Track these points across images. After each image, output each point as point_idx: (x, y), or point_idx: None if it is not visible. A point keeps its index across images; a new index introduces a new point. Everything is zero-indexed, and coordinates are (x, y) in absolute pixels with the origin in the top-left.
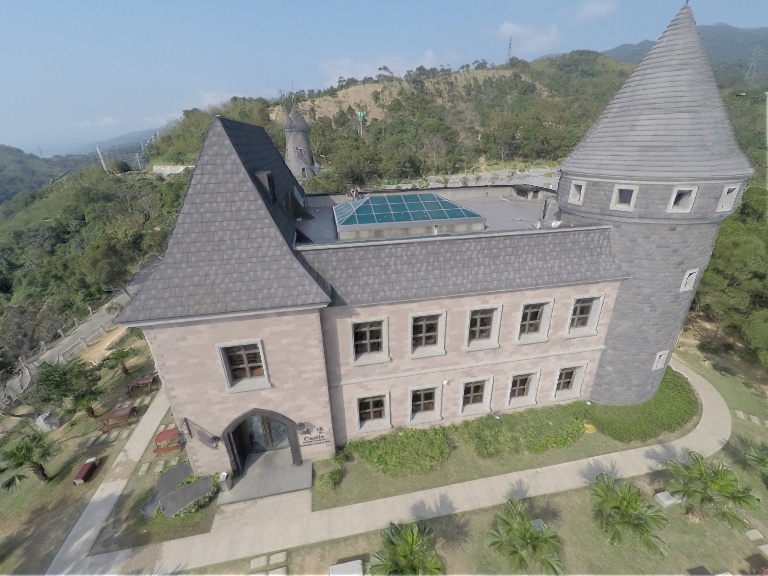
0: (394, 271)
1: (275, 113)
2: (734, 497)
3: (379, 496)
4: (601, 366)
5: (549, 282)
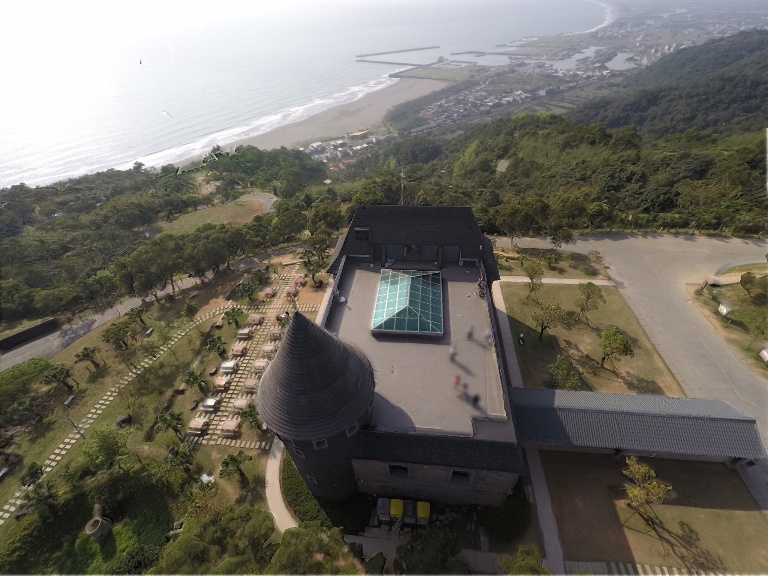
0: None
1: None
2: (245, 413)
3: None
4: None
5: None
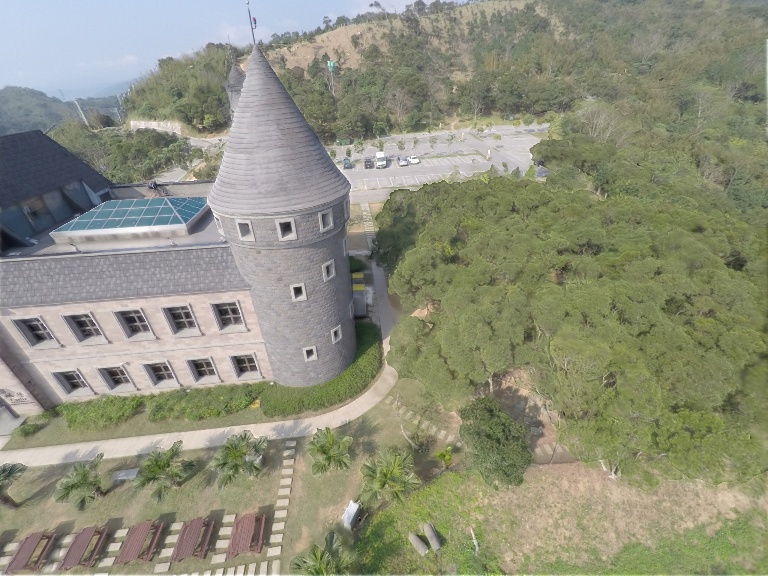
0: (36, 281)
1: (246, 63)
2: None
3: (54, 444)
4: (269, 355)
5: (173, 291)
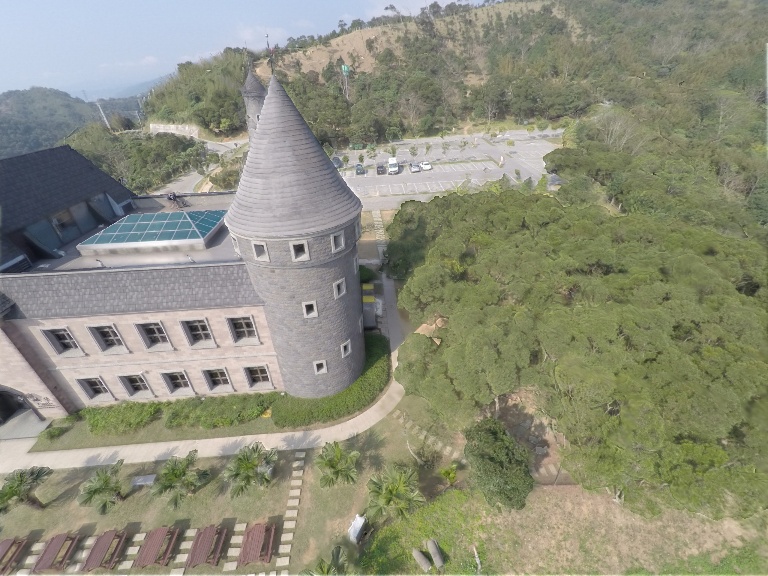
0: (64, 294)
1: (262, 67)
2: (248, 476)
3: (77, 447)
4: (280, 367)
5: (191, 306)
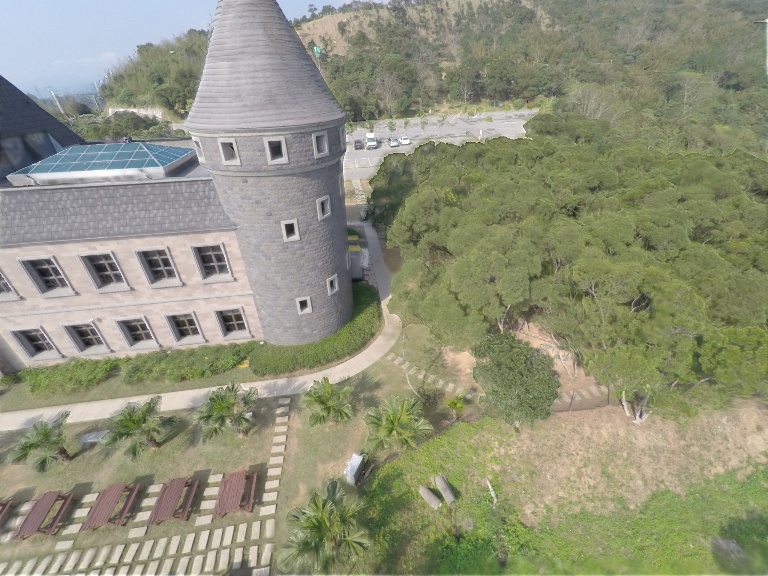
0: None
1: None
2: None
3: (14, 409)
4: (258, 310)
5: (149, 231)
